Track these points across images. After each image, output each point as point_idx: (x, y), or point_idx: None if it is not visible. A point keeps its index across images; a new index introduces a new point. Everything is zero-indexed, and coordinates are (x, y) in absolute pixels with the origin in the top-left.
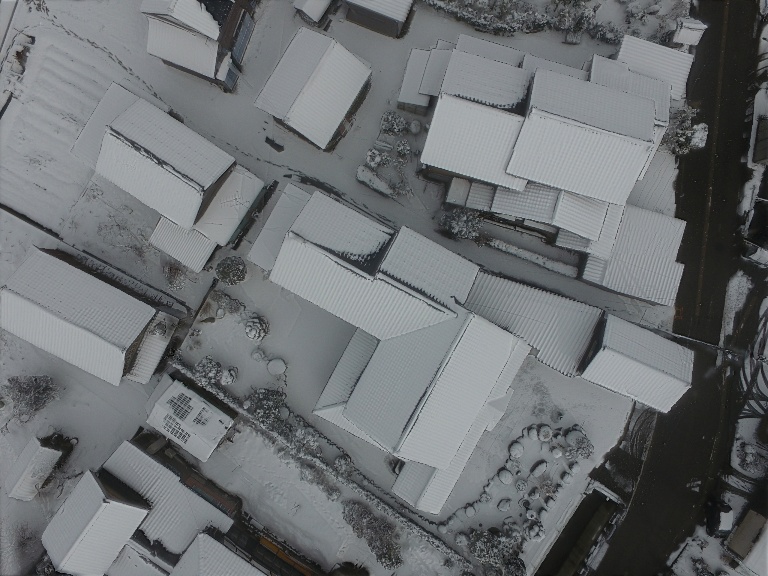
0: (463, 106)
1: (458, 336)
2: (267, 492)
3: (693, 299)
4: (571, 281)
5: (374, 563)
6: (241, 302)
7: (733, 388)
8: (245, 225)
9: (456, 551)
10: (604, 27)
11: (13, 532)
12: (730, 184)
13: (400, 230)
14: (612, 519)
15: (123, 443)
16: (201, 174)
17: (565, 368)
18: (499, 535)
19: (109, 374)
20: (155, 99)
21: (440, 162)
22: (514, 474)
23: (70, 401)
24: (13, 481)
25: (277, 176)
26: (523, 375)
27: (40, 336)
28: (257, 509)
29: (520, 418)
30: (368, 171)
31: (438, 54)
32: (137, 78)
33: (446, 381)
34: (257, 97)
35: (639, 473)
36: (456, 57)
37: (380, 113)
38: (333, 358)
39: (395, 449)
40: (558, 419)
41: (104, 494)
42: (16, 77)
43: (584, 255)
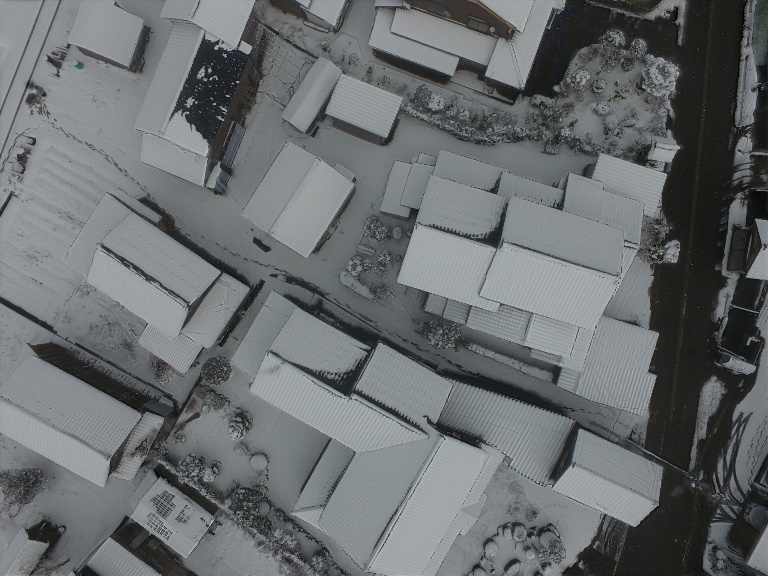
0: (437, 236)
1: (429, 458)
2: None
3: (667, 403)
4: (547, 383)
5: None
6: (226, 397)
7: (706, 492)
8: (232, 322)
9: None
10: (581, 143)
11: None
12: (704, 291)
13: (376, 347)
14: None
15: (107, 540)
16: (187, 289)
17: (537, 477)
18: None
19: (95, 476)
20: (146, 208)
21: (416, 283)
22: (489, 572)
23: (59, 490)
24: (1, 572)
25: (263, 275)
26: (499, 474)
27: (30, 439)
28: None
29: (495, 516)
30: (350, 276)
31: (419, 168)
32: (131, 179)
33: (417, 499)
34: (244, 207)
35: (612, 574)
36: (433, 184)
37: (364, 217)
38: (314, 453)
39: (366, 566)
40: (533, 518)
41: None
42: (16, 177)
43: None
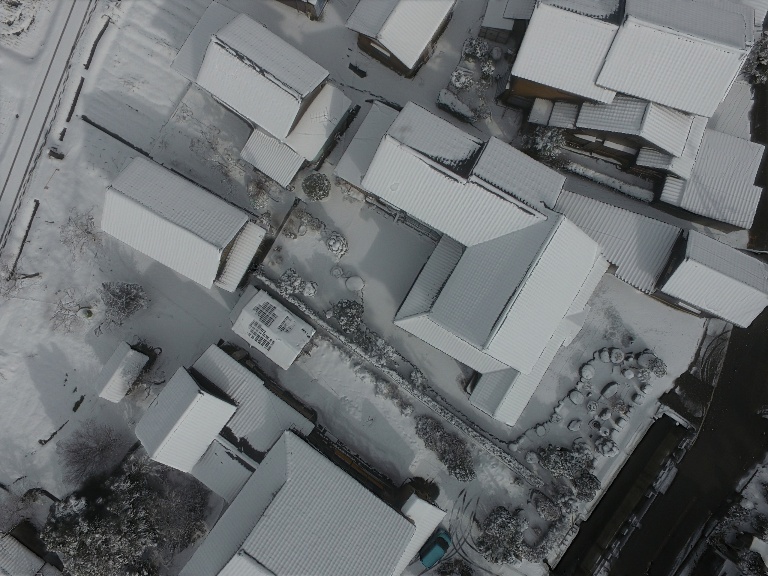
0: (558, 15)
1: (549, 237)
2: (342, 405)
3: (767, 228)
4: (645, 207)
5: (444, 479)
6: (321, 221)
7: None
8: (327, 147)
9: (527, 468)
10: None
11: (101, 432)
12: None
13: (490, 139)
14: (681, 444)
15: (211, 346)
16: (299, 83)
17: (643, 285)
18: (572, 451)
19: (203, 276)
20: (251, 18)
21: (531, 74)
22: (585, 396)
23: (155, 312)
24: (103, 382)
25: (359, 101)
26: (595, 299)
27: (139, 237)
28: (332, 421)
29: (591, 341)
30: (450, 94)
31: None
32: None
33: (534, 282)
34: (348, 18)
35: (709, 399)
36: None
37: (461, 41)
38: (409, 278)
39: (484, 346)
40: (629, 343)
41: (199, 386)
42: (114, 3)
43: (661, 179)
